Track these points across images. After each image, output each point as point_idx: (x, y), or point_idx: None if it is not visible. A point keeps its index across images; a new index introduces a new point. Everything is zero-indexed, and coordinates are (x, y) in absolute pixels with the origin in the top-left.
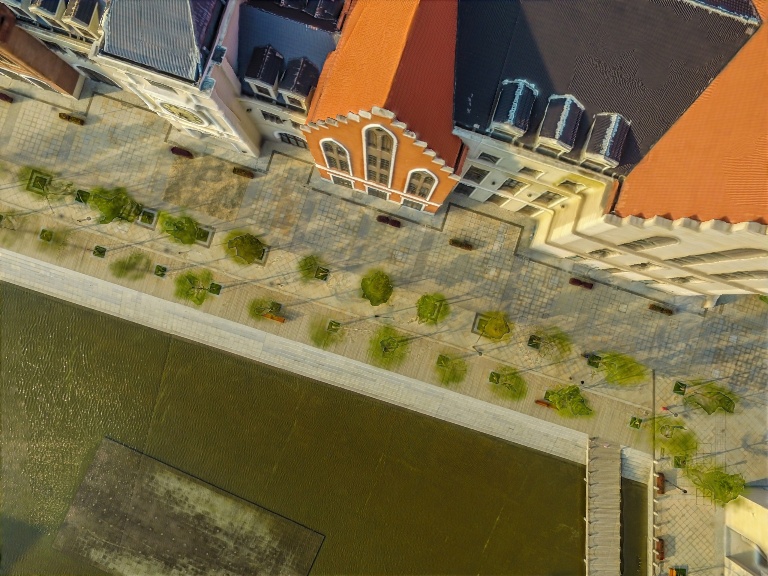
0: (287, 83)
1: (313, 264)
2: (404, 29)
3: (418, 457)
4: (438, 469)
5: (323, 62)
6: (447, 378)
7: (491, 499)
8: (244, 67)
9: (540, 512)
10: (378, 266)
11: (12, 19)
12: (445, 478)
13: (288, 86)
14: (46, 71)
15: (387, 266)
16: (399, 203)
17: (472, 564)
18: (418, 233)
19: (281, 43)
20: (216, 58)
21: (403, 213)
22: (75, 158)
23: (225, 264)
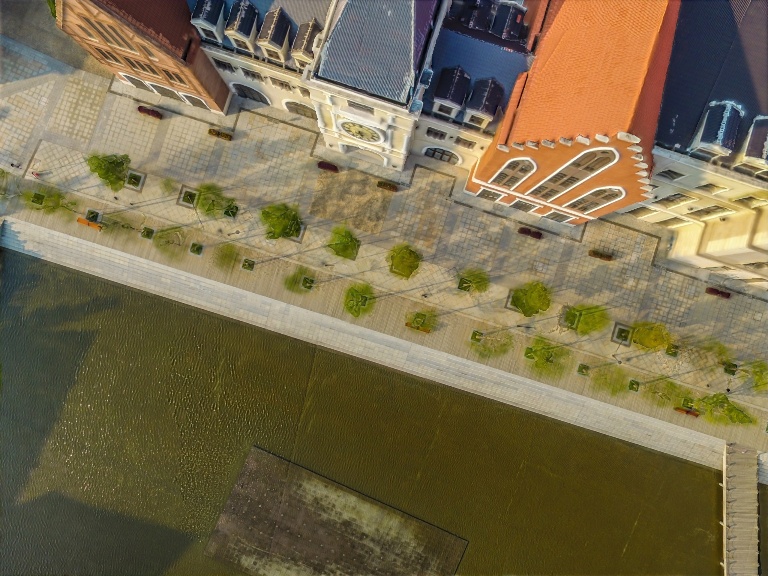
0: (476, 103)
1: (456, 275)
2: (642, 56)
3: (558, 464)
4: (577, 475)
5: (512, 82)
6: (588, 386)
7: (629, 504)
8: (432, 87)
9: (677, 517)
10: (519, 277)
11: (198, 41)
12: (584, 484)
13: (477, 106)
14: (211, 89)
15: (528, 277)
16: (541, 215)
17: (611, 568)
18: (558, 244)
19: (471, 64)
20: (423, 81)
21: (543, 225)
22: (223, 173)
23: (370, 276)
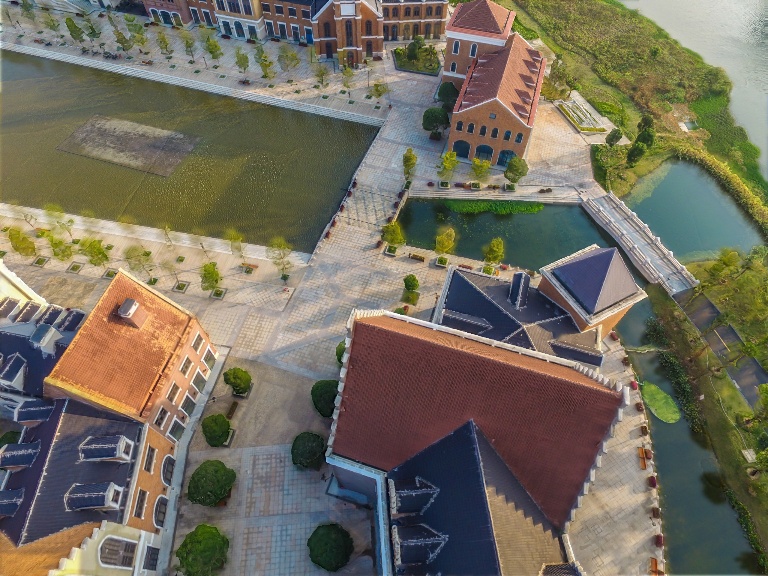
0: None
1: (5, 259)
2: None
3: None
4: None
5: None
6: None
7: None
8: None
9: None
10: None
11: None
12: None
13: None
14: None
15: None
16: None
17: None
18: None
19: None
20: None
21: None
22: None
23: None
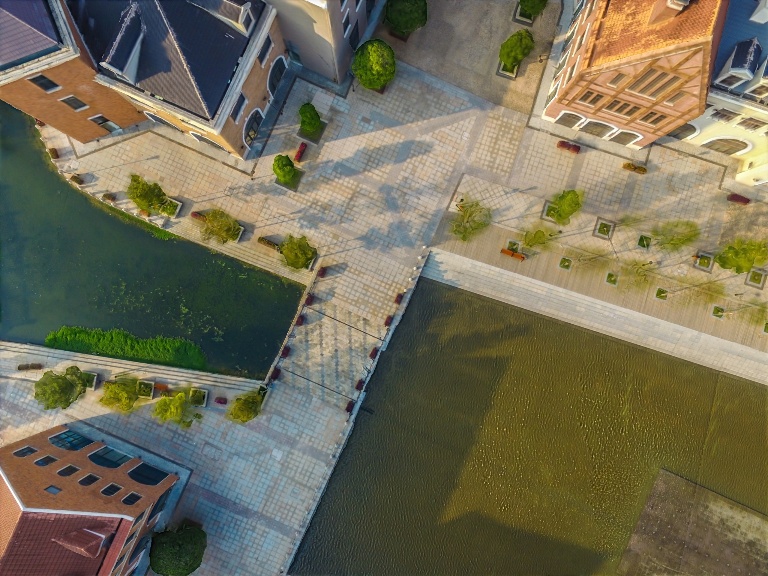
0: None
1: None
2: None
3: None
4: None
5: None
6: None
7: None
8: None
9: None
10: None
11: None
12: None
13: None
14: None
15: None
16: None
17: None
18: None
19: None
20: None
21: None
22: (636, 205)
23: None
